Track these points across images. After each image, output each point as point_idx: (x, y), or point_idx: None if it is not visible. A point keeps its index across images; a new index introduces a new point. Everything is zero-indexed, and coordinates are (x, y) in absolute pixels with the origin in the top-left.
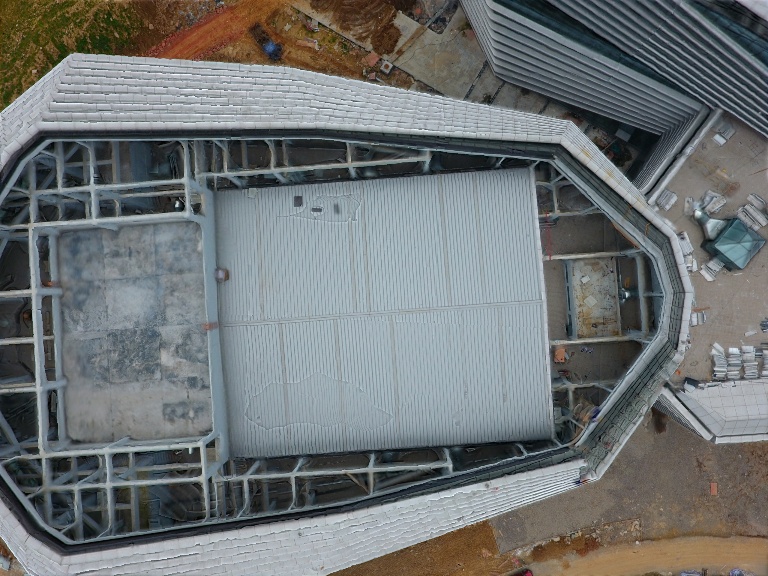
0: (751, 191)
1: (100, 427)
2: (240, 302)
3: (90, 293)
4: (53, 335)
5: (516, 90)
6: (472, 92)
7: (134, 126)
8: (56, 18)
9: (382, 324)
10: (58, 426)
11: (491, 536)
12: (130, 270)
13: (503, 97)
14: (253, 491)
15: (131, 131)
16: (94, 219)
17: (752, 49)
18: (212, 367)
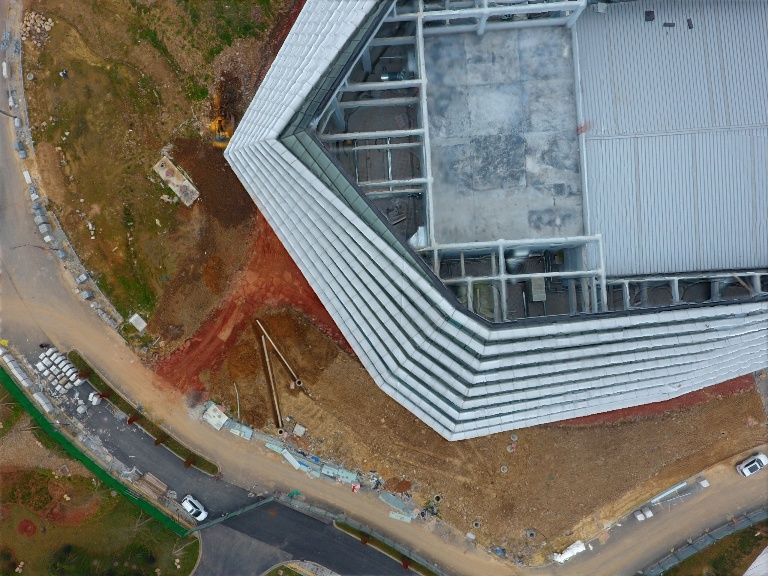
0: None
1: (463, 234)
2: (593, 116)
3: (452, 99)
4: None
5: None
6: None
7: None
8: None
9: (742, 139)
10: (428, 229)
11: (759, 403)
12: (494, 76)
13: None
14: (635, 293)
15: None
16: (486, 8)
17: None
18: (586, 170)
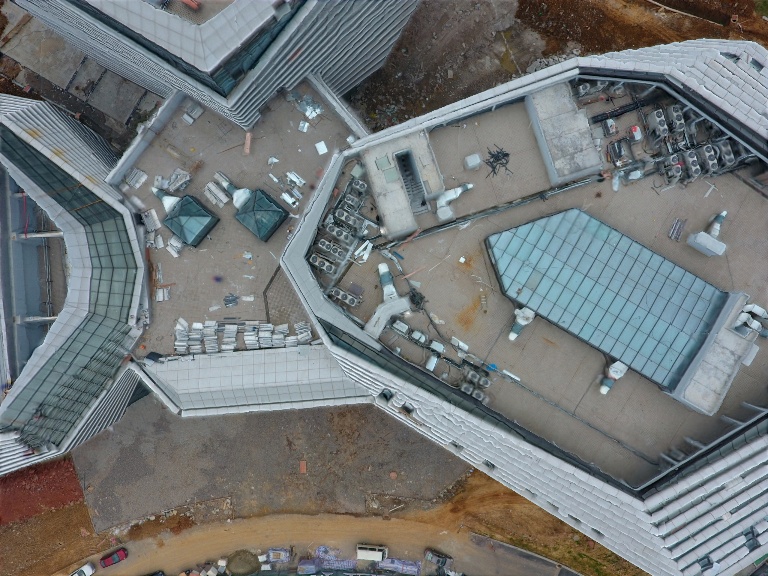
0: (218, 169)
1: None
2: None
3: None
4: None
5: (117, 76)
6: (76, 78)
7: None
8: None
9: None
10: None
11: (87, 515)
12: None
13: (106, 83)
14: None
15: None
16: None
17: (116, 26)
18: None
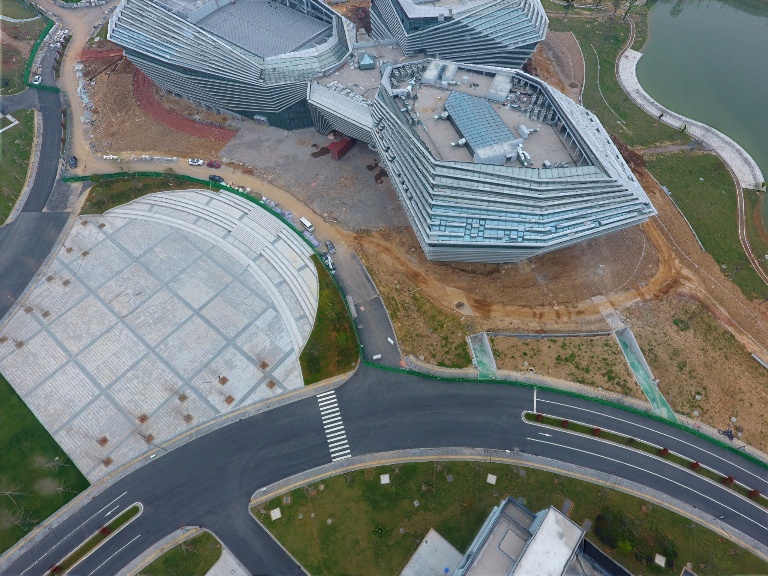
0: (387, 60)
1: None
2: (230, 8)
3: None
4: None
5: None
6: None
7: None
8: None
9: None
10: None
11: (222, 148)
12: None
13: None
14: None
15: None
16: None
17: None
18: (206, 5)
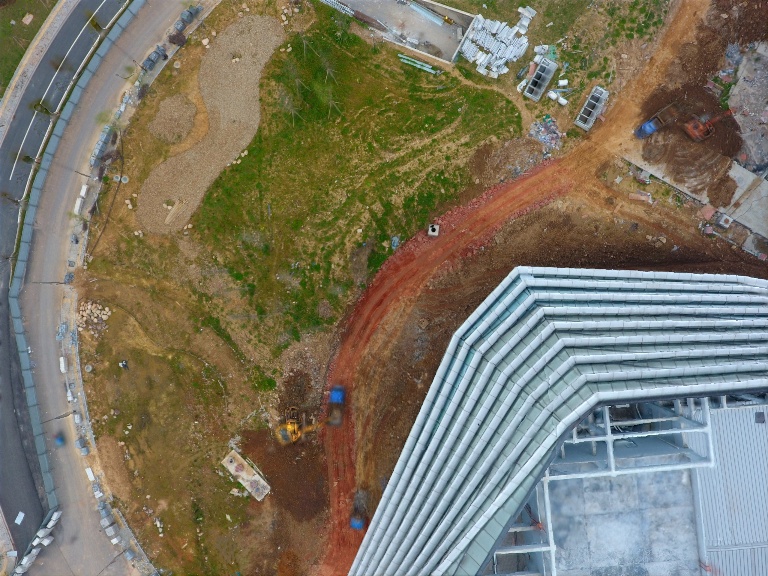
0: None
1: None
2: (708, 526)
3: (570, 529)
4: (531, 573)
5: None
6: None
7: (689, 390)
8: (385, 177)
9: None
10: None
11: None
12: (612, 504)
13: None
14: None
15: (685, 394)
16: (613, 471)
17: None
18: None
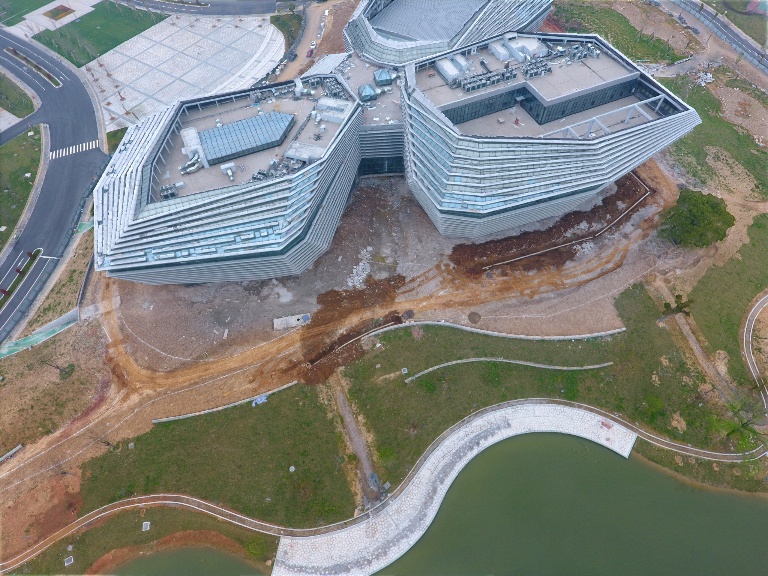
0: None
1: None
2: None
3: None
4: None
5: None
6: None
7: None
8: None
9: None
10: None
11: None
12: None
13: None
14: None
15: None
16: None
17: None
18: None
